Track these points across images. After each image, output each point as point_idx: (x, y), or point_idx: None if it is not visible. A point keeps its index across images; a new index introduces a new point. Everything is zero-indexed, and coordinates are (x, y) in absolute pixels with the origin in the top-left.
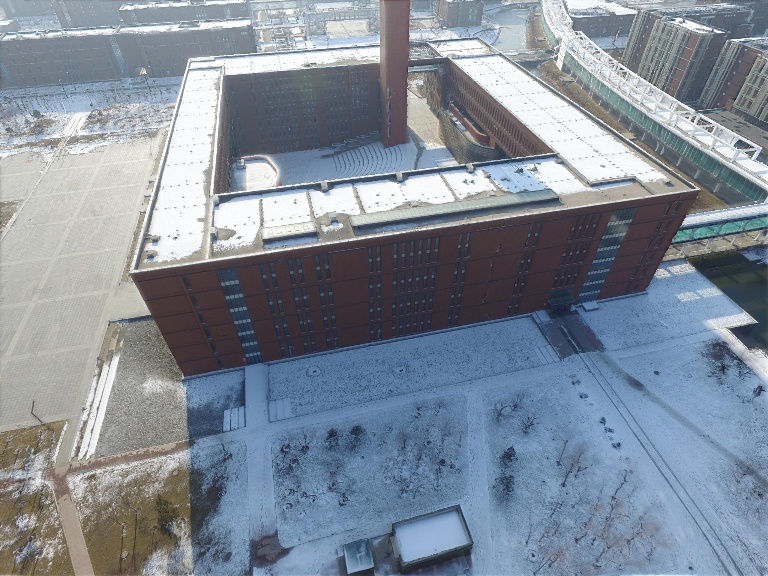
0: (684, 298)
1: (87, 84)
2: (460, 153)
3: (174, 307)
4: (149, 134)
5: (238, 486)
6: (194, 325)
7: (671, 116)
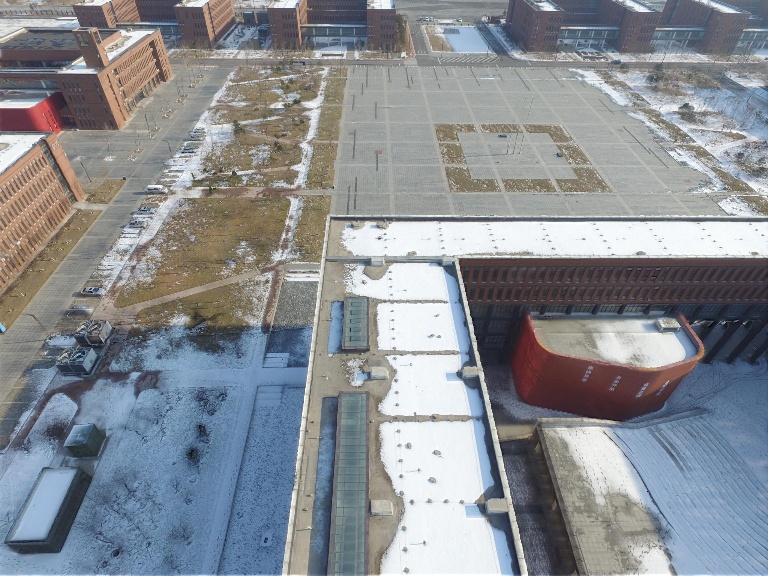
0: None
1: None
2: None
3: None
4: None
5: (209, 363)
6: None
7: None
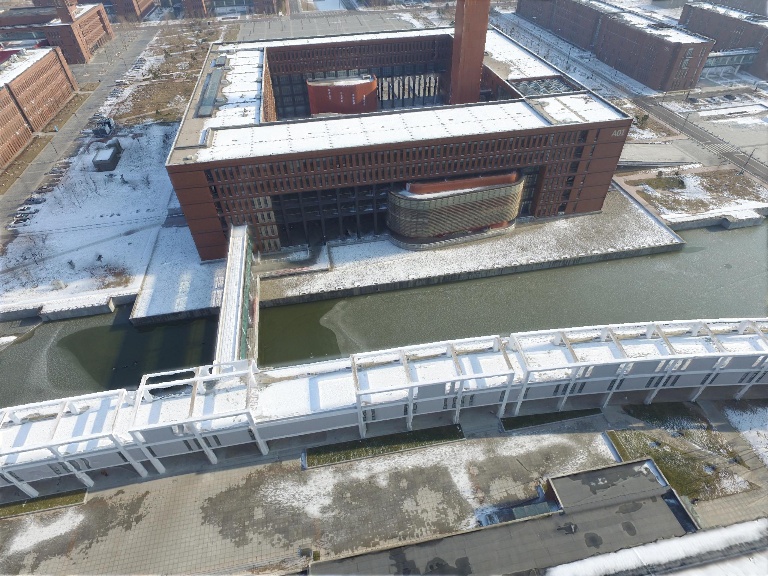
0: (184, 285)
1: None
2: None
3: None
4: None
5: (166, 128)
6: None
7: (510, 337)
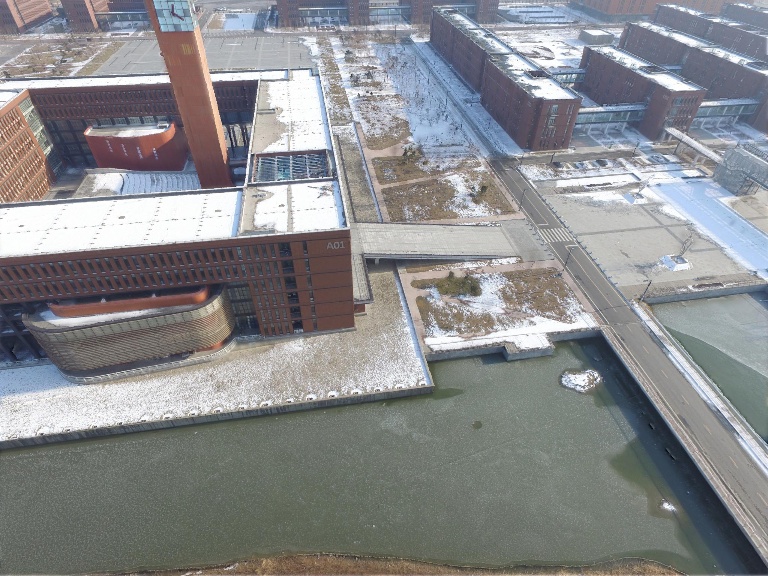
0: None
1: (461, 84)
2: None
3: None
4: (340, 117)
5: None
6: None
7: None
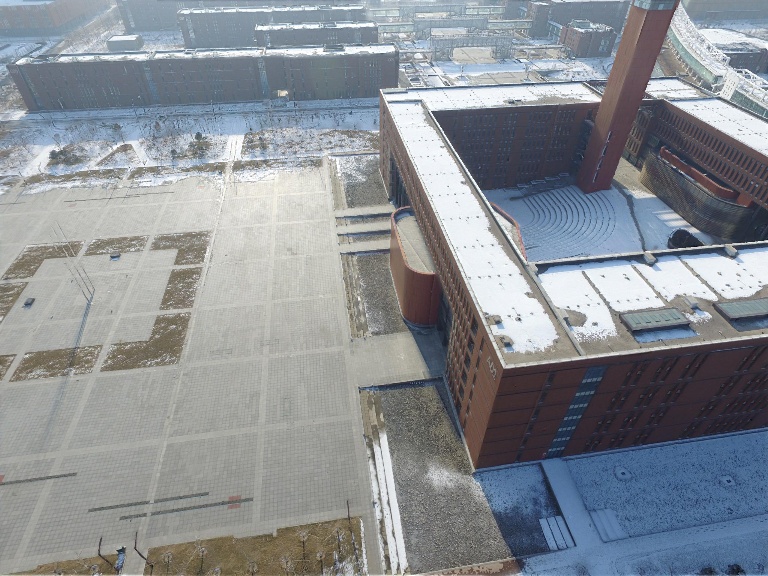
0: None
1: (230, 105)
2: (687, 206)
3: (519, 402)
4: (314, 163)
5: None
6: (524, 420)
7: None
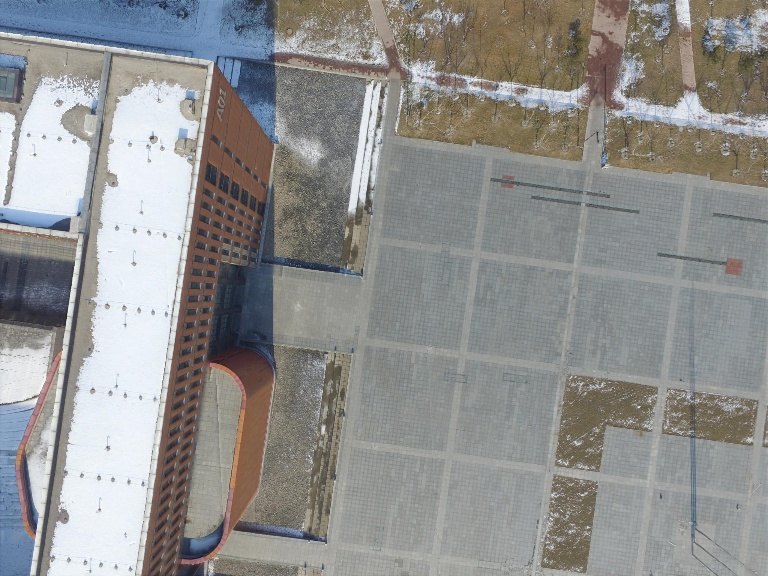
0: None
1: None
2: None
3: None
4: None
5: None
6: None
7: None
